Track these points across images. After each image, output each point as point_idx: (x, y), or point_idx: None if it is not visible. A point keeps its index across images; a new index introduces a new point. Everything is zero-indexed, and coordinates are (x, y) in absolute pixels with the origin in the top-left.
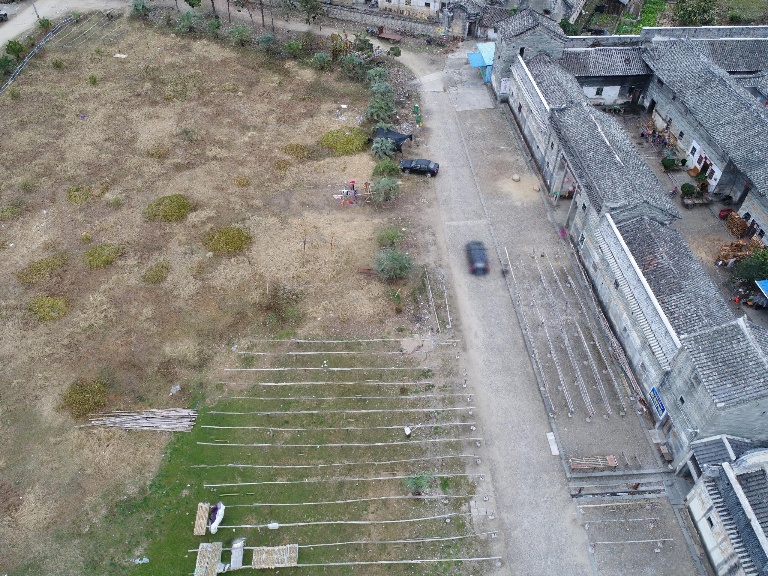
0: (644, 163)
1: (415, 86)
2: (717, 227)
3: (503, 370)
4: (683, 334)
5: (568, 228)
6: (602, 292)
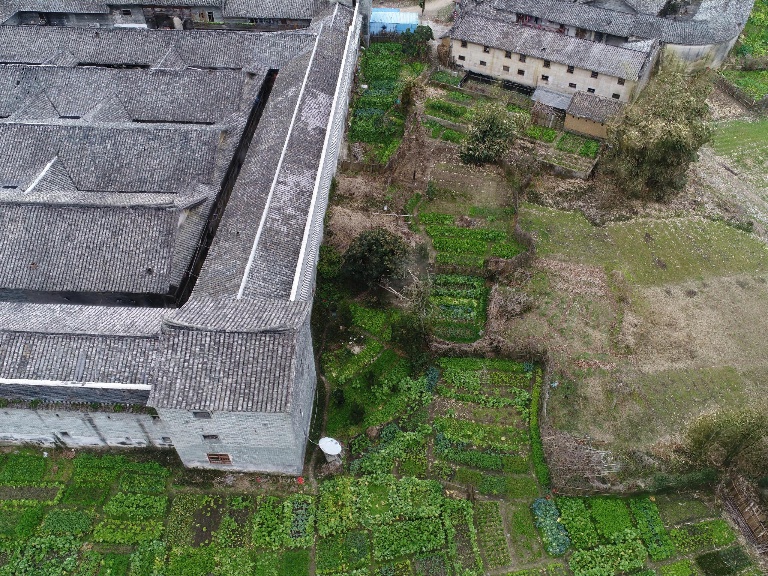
0: (160, 3)
1: (376, 7)
2: None
3: None
4: None
5: None
6: None
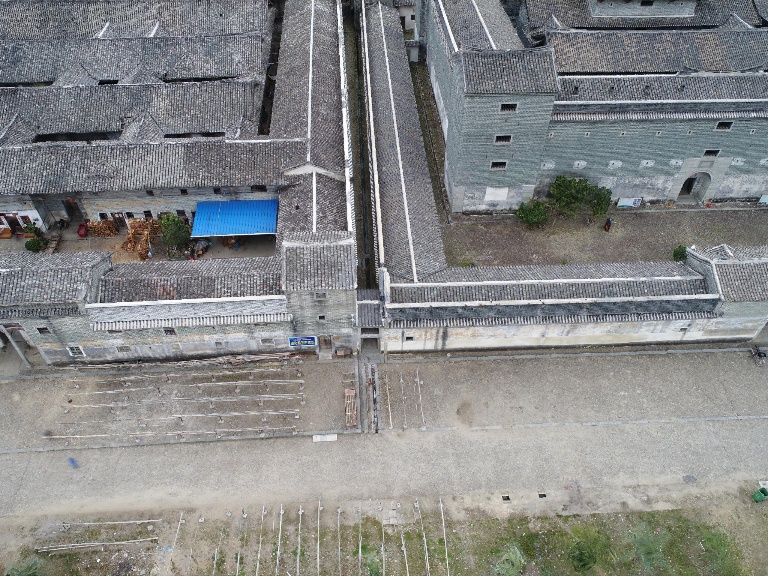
0: (8, 256)
1: None
2: (94, 243)
3: (230, 471)
4: (261, 294)
5: (35, 365)
6: (159, 352)
